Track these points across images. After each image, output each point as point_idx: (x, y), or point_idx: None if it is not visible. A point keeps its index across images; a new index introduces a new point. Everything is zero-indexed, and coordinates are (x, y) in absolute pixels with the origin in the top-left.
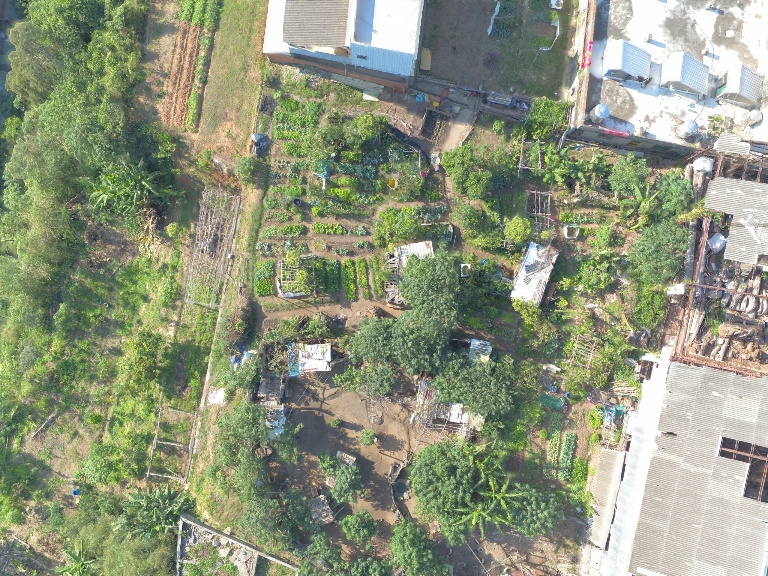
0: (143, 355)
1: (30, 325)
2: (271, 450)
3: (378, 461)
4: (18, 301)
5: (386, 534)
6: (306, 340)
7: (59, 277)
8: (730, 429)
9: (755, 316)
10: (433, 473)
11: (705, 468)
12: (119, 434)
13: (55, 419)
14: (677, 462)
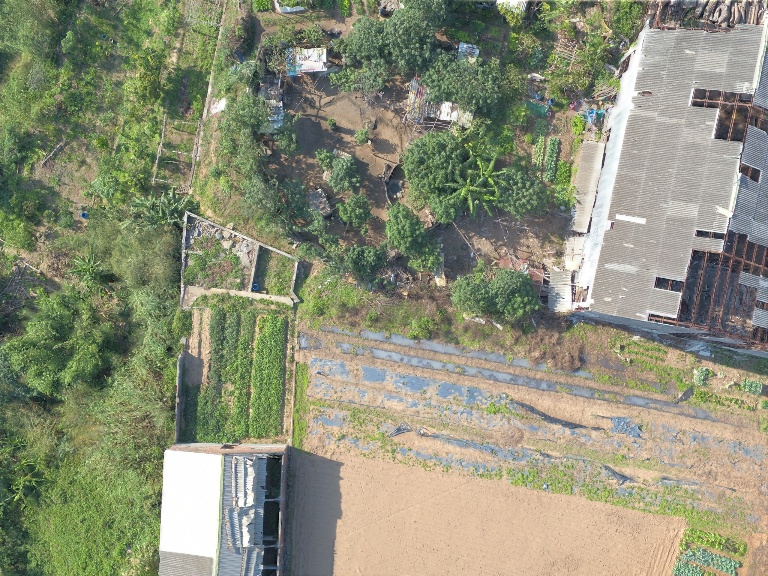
0: (147, 71)
1: (39, 51)
2: (271, 152)
3: (372, 163)
4: (27, 27)
5: (380, 230)
6: (303, 44)
7: (65, 16)
8: (701, 81)
9: (727, 25)
10: (424, 152)
11: (678, 118)
12: (125, 158)
13: (63, 148)
14: (652, 116)
